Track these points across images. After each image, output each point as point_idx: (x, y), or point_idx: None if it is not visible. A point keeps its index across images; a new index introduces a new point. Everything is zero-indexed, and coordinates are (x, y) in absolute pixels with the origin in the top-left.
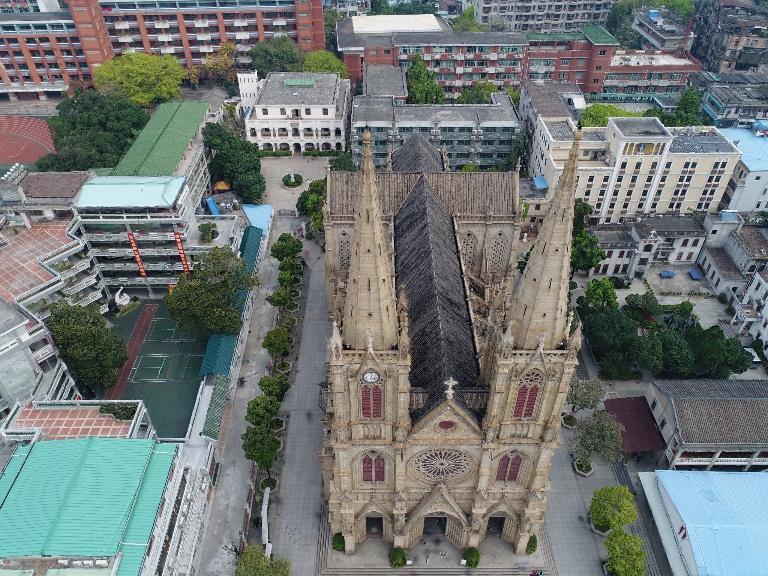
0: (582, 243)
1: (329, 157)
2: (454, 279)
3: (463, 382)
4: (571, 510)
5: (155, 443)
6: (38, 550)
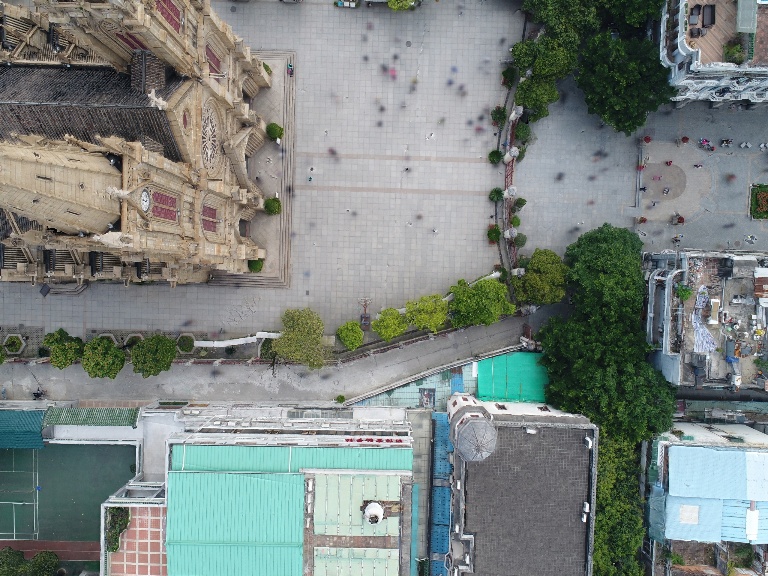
0: None
1: None
2: None
3: (124, 89)
4: (224, 17)
5: (171, 471)
6: (298, 551)
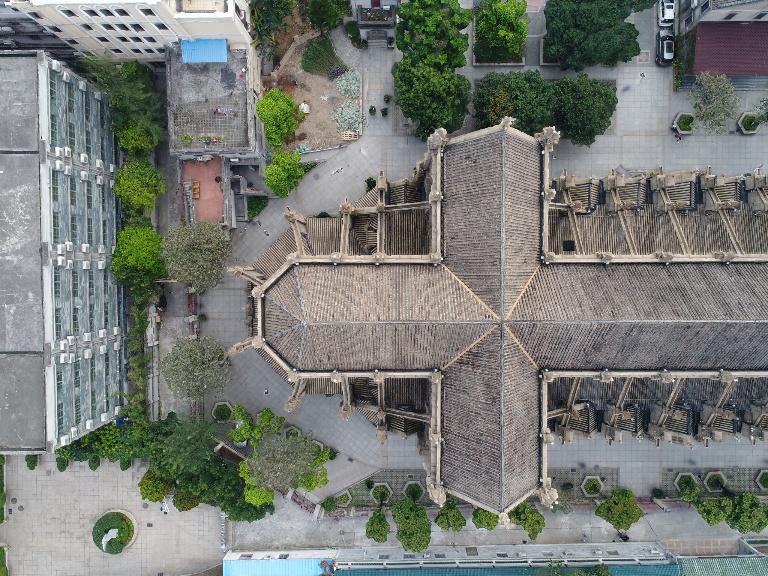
0: (445, 24)
1: (4, 468)
2: (761, 281)
3: None
4: None
5: None
6: None
